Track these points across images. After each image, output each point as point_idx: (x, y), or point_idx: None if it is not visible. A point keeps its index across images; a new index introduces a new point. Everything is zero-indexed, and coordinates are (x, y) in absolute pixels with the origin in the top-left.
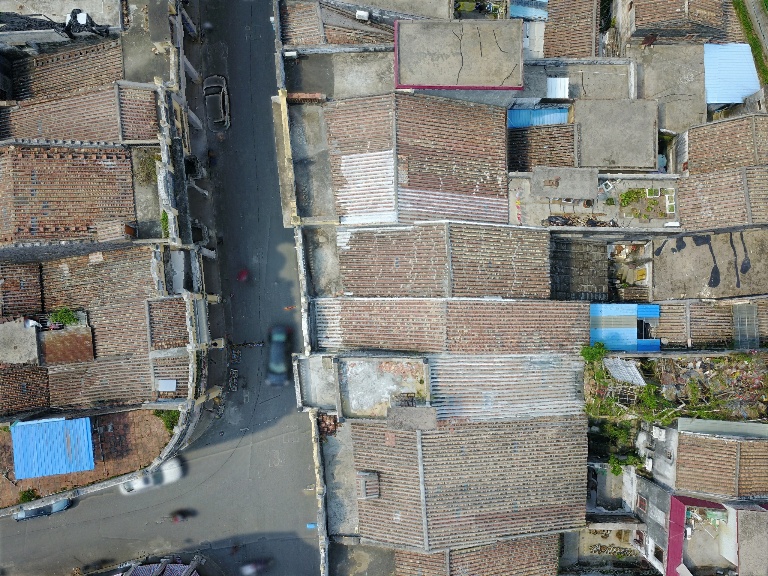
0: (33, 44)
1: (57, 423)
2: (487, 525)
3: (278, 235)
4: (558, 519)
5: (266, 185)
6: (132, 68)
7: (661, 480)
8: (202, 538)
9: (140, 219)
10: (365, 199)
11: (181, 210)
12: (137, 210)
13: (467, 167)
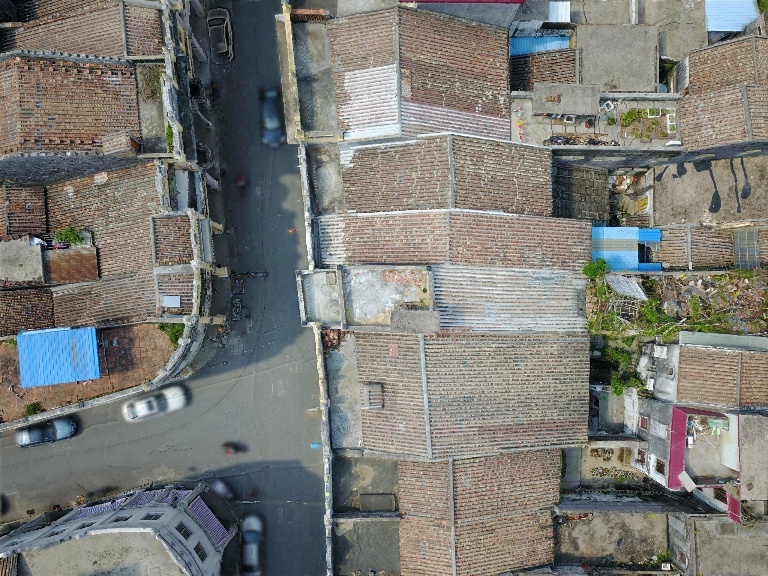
0: None
1: (63, 332)
2: (490, 437)
3: (281, 167)
4: (560, 434)
5: (269, 117)
6: None
7: (663, 397)
8: (206, 466)
9: (145, 135)
10: (368, 114)
11: (186, 126)
12: (142, 126)
13: (470, 85)
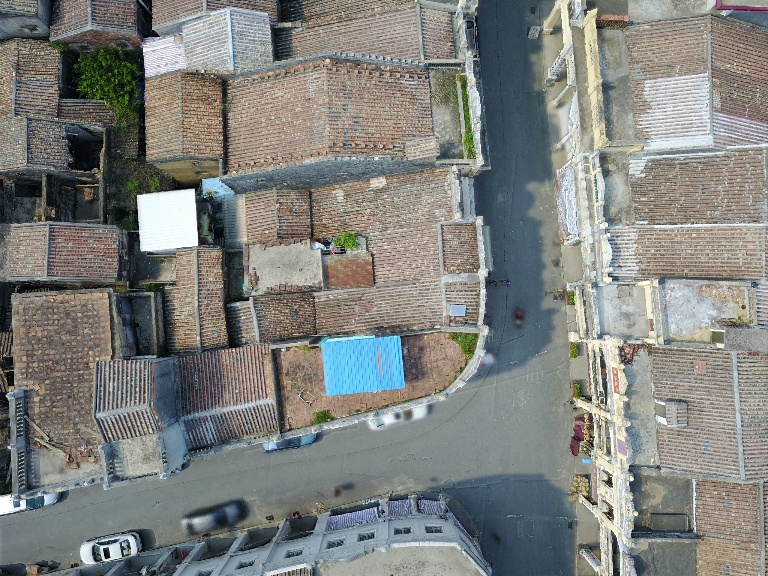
0: None
1: (368, 340)
2: None
3: (523, 174)
4: None
5: (512, 123)
6: None
7: None
8: (445, 477)
9: None
10: (673, 123)
11: None
12: (435, 131)
13: (767, 96)
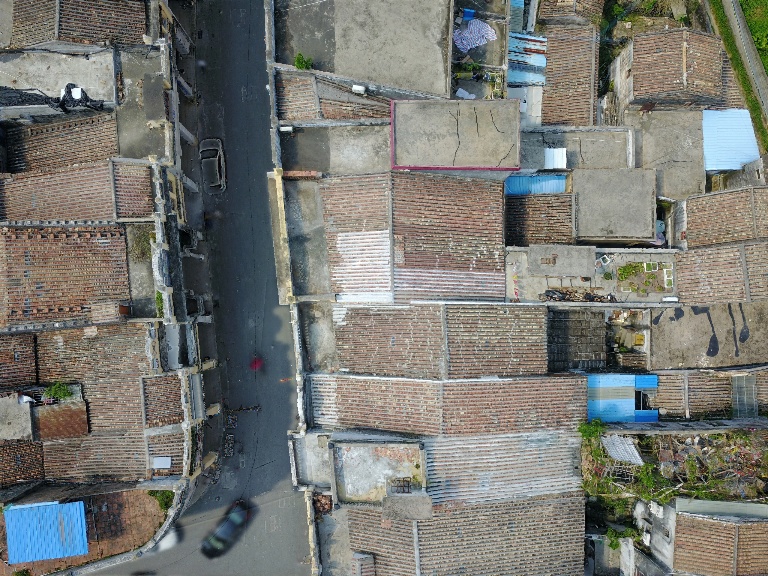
0: (27, 116)
1: (51, 507)
2: None
3: (274, 298)
4: None
5: (262, 248)
6: (127, 143)
7: (659, 557)
8: None
9: (135, 296)
10: (361, 278)
11: (176, 287)
12: (132, 287)
13: (464, 243)
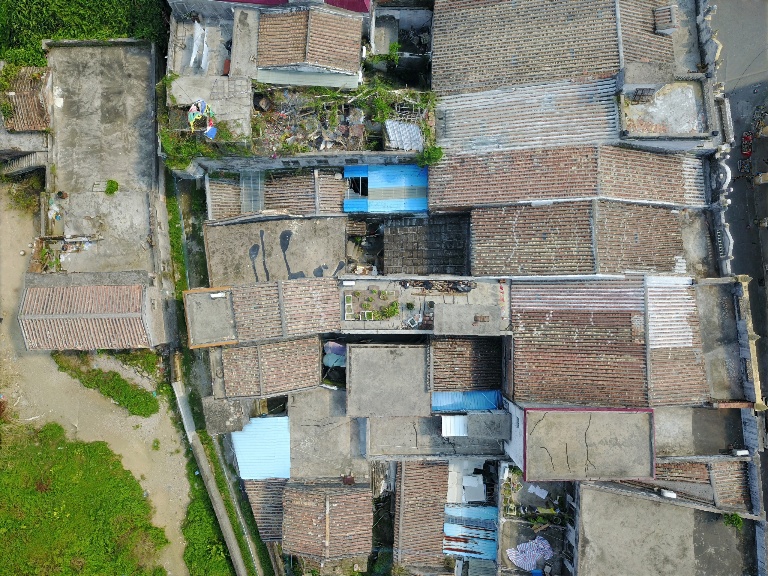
0: None
1: None
2: None
3: None
4: None
5: None
6: None
7: None
8: None
9: None
10: (672, 301)
11: None
12: None
13: (560, 338)
